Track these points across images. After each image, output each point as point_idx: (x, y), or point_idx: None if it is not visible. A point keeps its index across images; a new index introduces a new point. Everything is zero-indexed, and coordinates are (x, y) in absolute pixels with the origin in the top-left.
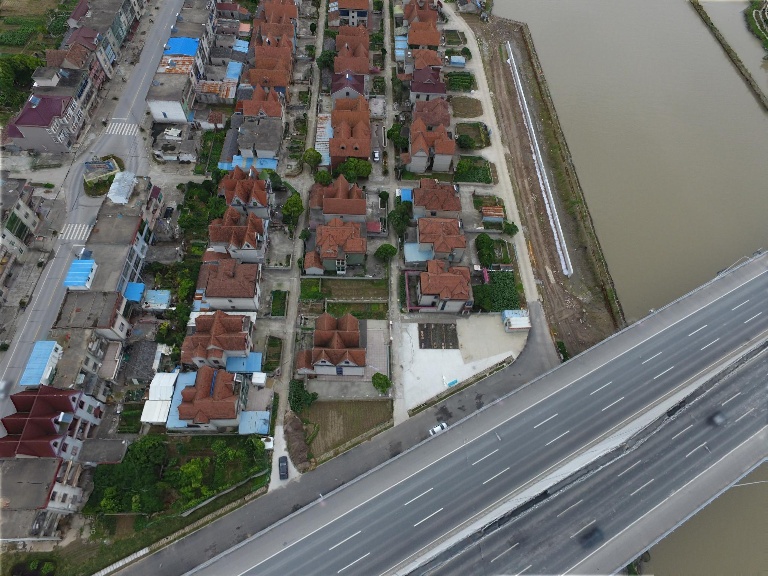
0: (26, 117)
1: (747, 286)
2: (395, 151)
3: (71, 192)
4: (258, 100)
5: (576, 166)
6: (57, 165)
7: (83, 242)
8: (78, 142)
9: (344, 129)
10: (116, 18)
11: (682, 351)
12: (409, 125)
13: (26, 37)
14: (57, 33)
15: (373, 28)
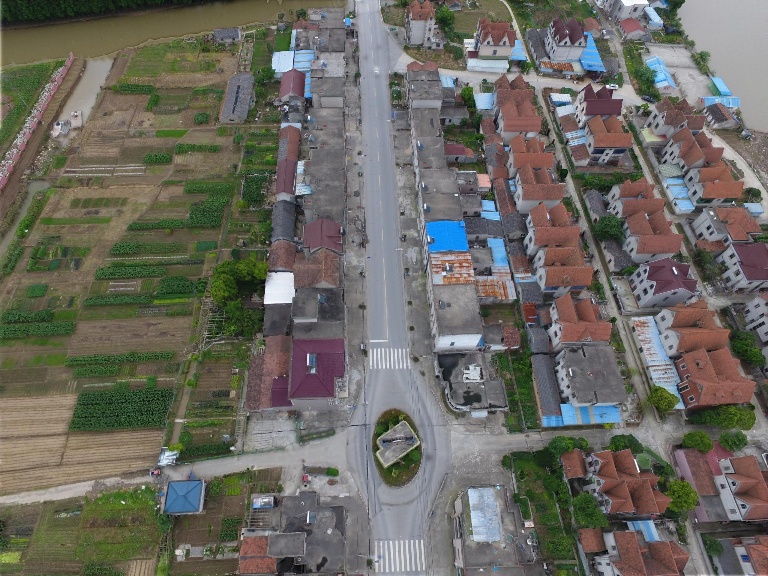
0: (304, 387)
1: None
2: (743, 367)
3: (363, 480)
4: (577, 320)
5: None
6: (330, 432)
7: (411, 575)
8: (343, 388)
9: (711, 364)
10: (344, 192)
11: None
12: (739, 319)
13: (221, 214)
14: (255, 204)
15: (625, 163)
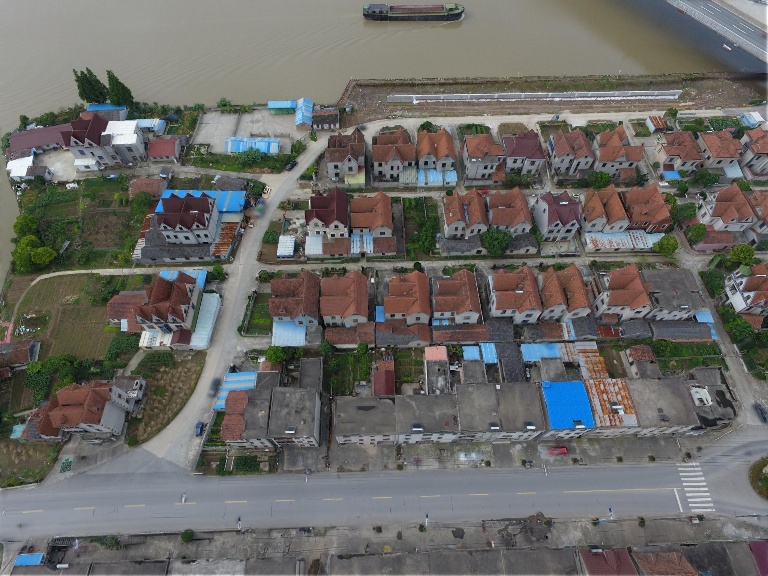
0: None
1: (689, 5)
2: None
3: None
4: None
5: (563, 75)
6: None
7: None
8: None
9: None
10: None
11: (761, 38)
12: None
13: None
14: None
15: None
